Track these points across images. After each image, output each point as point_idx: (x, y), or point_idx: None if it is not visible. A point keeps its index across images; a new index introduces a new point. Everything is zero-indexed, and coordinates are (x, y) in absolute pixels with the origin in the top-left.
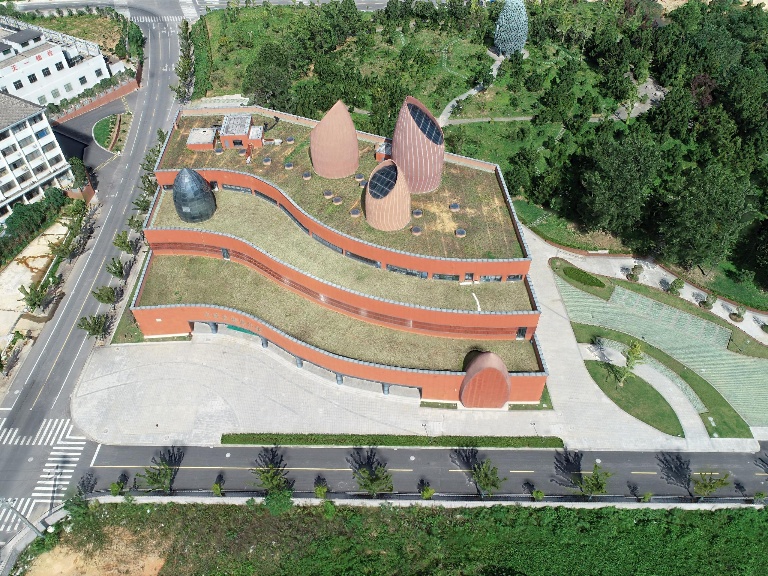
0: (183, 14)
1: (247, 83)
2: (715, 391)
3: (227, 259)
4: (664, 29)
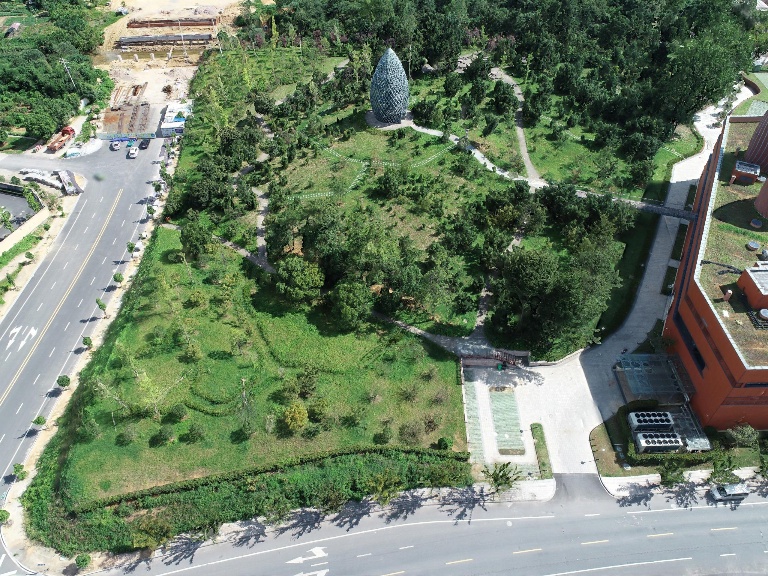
0: None
1: (604, 305)
2: None
3: None
4: (395, 22)
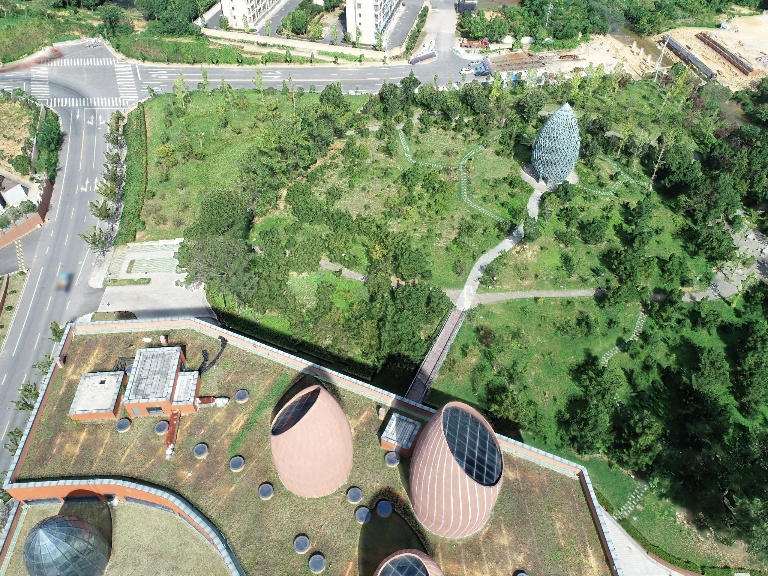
0: (119, 94)
1: (183, 258)
2: None
3: None
4: (761, 148)
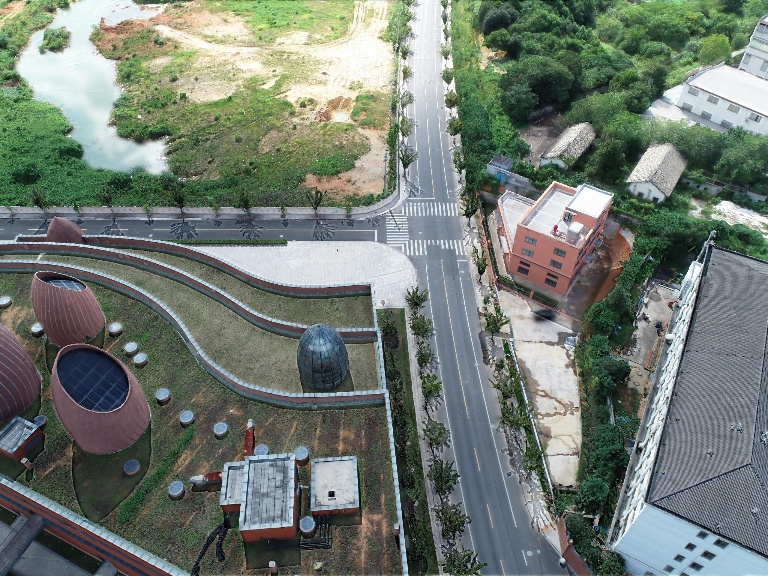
0: None
1: None
2: None
3: None
4: None
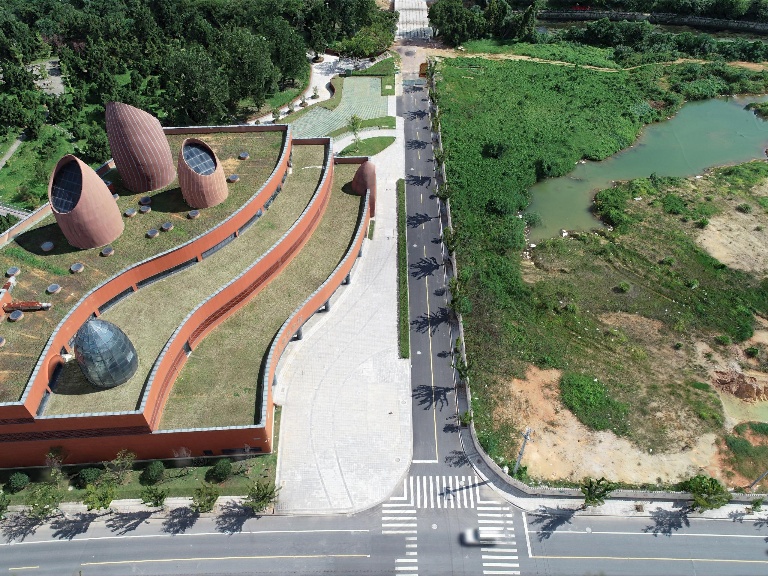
0: None
1: None
2: (364, 121)
3: (189, 355)
4: None
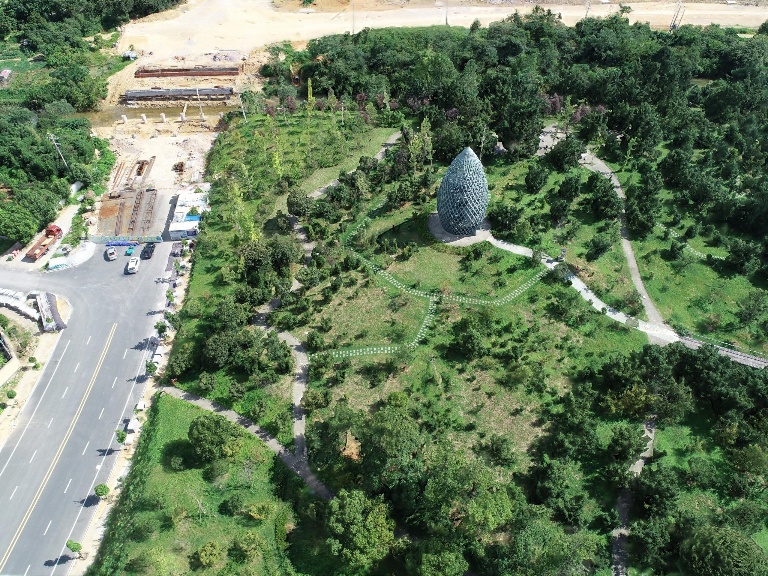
0: None
1: None
2: None
3: None
4: (458, 88)
